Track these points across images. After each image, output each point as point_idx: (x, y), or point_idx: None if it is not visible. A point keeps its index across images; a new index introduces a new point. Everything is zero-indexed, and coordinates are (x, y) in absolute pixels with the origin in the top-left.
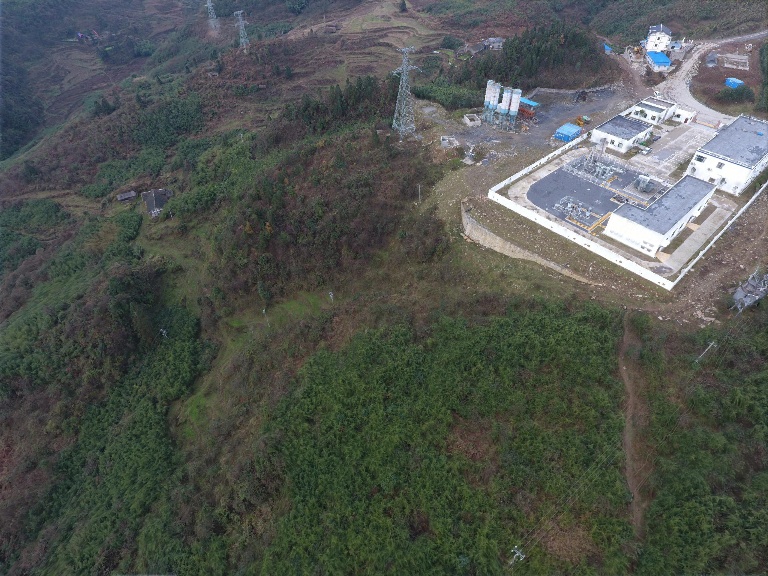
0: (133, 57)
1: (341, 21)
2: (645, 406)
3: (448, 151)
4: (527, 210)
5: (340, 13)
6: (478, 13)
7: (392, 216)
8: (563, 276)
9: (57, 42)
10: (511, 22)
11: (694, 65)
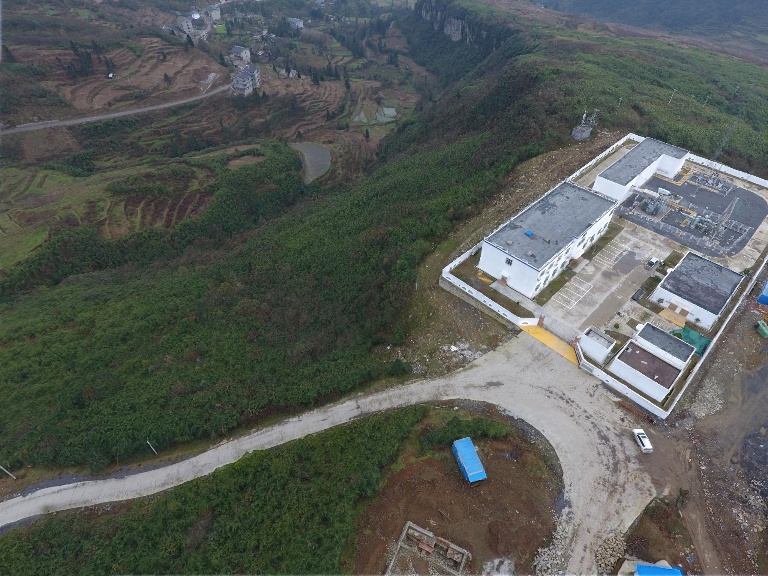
0: None
1: None
2: None
3: None
4: (756, 177)
5: None
6: None
7: None
8: None
9: None
10: None
11: None
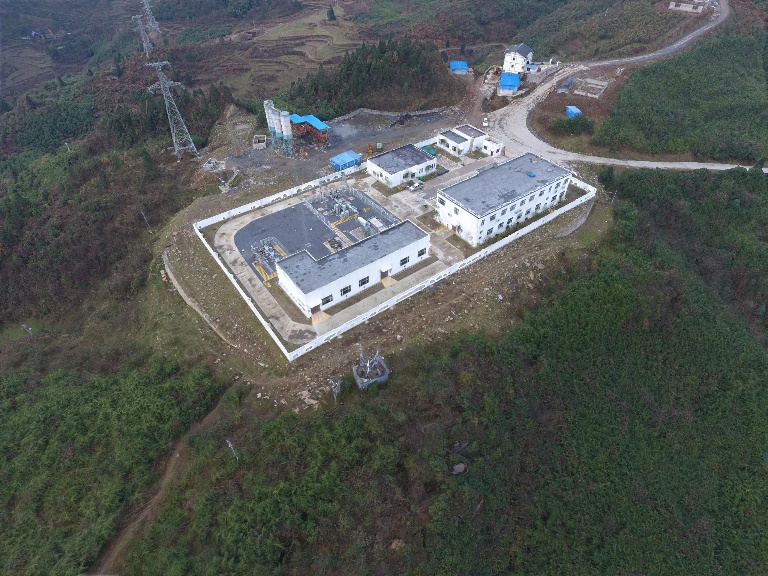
0: (87, 57)
1: (268, 27)
2: (158, 509)
3: (208, 175)
4: (211, 251)
5: (278, 19)
6: (399, 24)
7: (121, 244)
8: (211, 331)
9: (10, 40)
10: (425, 34)
11: (547, 90)
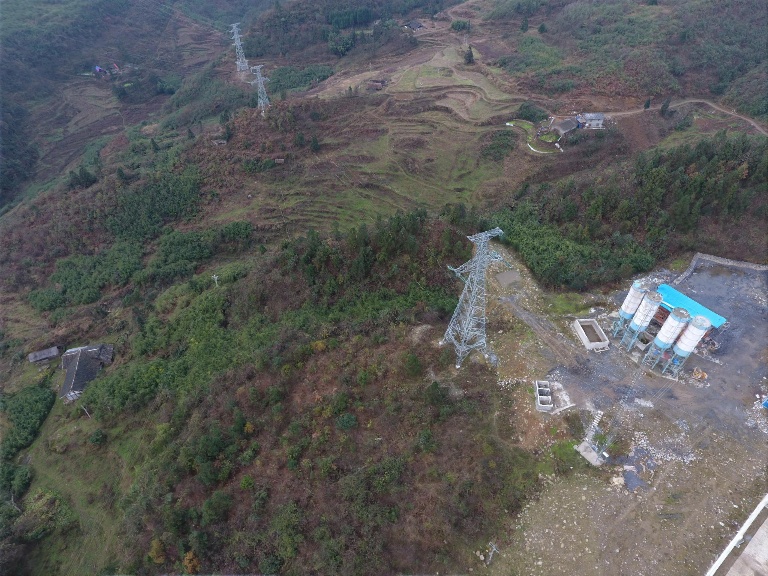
0: (155, 94)
1: (390, 72)
2: None
3: (550, 423)
4: None
5: (391, 58)
6: (568, 73)
7: None
8: None
9: (72, 76)
10: (615, 91)
11: None
